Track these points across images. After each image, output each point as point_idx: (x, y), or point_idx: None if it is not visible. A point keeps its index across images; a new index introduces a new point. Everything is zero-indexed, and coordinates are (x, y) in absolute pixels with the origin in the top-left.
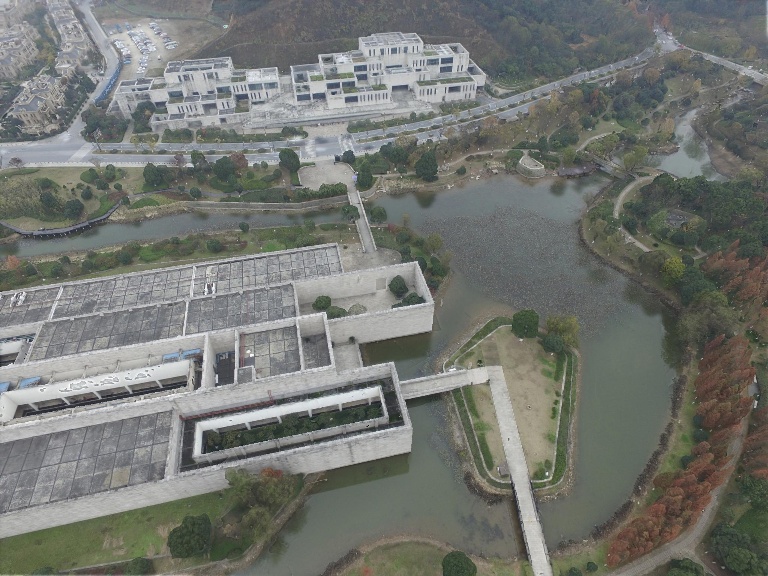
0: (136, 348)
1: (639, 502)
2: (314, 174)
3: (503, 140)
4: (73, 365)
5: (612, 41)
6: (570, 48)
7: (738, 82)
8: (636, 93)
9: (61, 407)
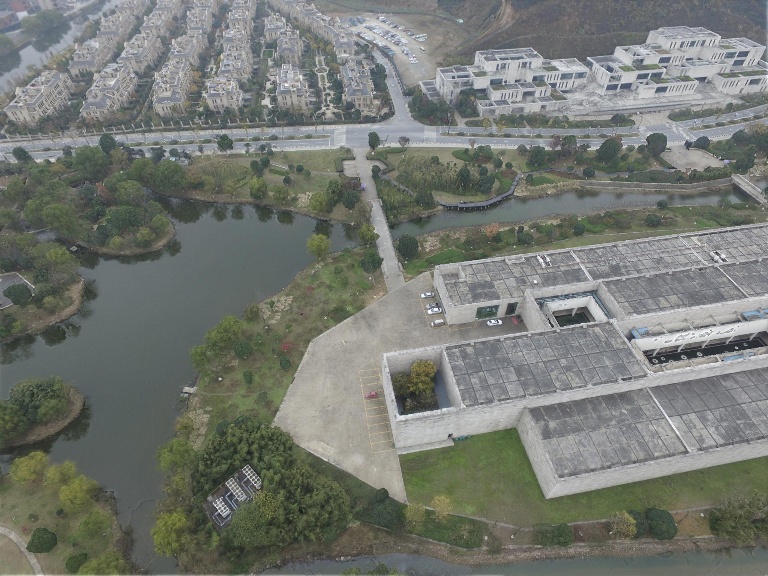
0: (735, 304)
1: None
2: (677, 158)
3: None
4: (678, 318)
5: None
6: None
7: None
8: None
9: (647, 358)
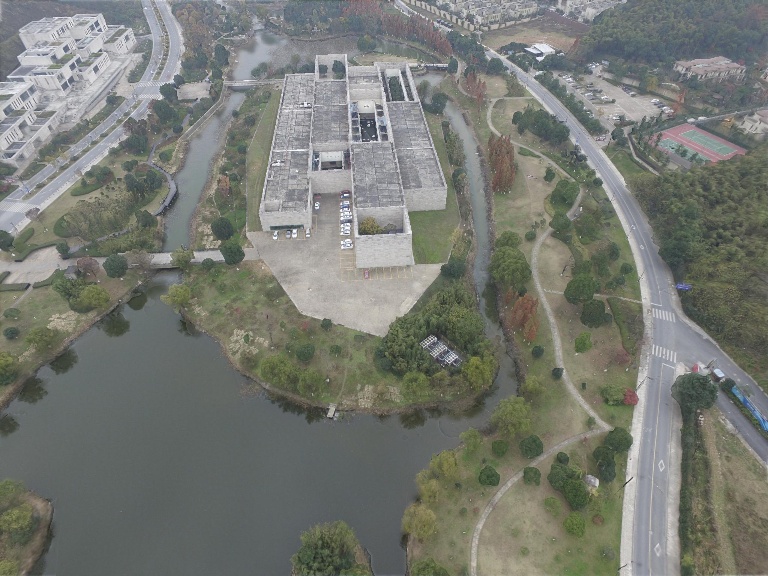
0: None
1: (432, 53)
2: (185, 95)
3: None
4: None
5: None
6: None
7: None
8: (196, 1)
9: None
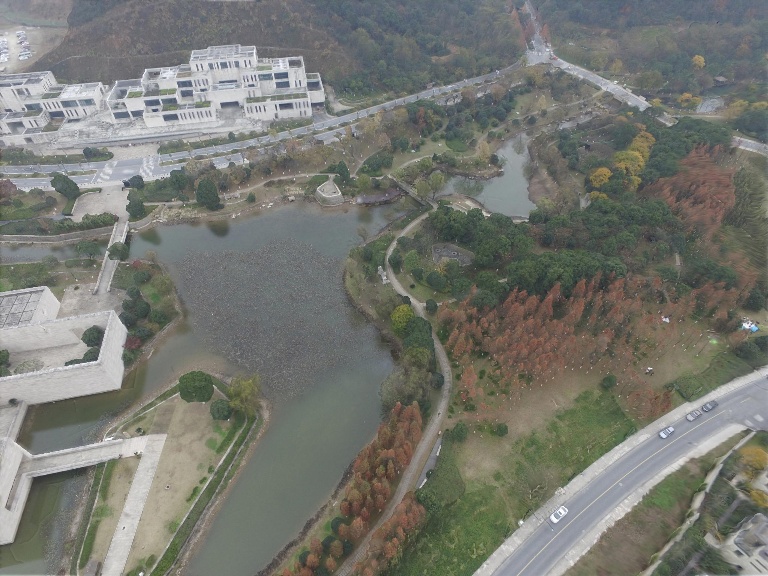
0: None
1: None
2: (94, 201)
3: (311, 163)
4: None
5: (477, 54)
6: (430, 61)
7: (595, 98)
8: (474, 111)
9: None
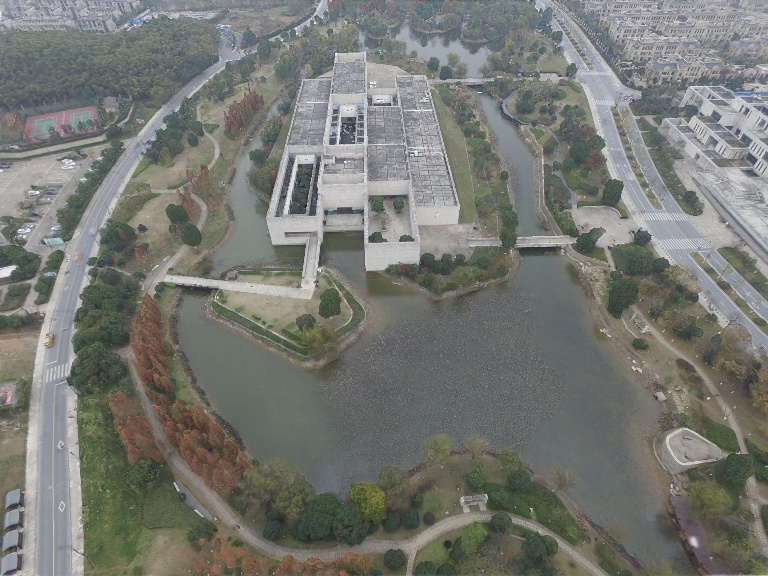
0: None
1: None
2: (604, 217)
3: (761, 422)
4: None
5: None
6: None
7: None
8: None
9: None
